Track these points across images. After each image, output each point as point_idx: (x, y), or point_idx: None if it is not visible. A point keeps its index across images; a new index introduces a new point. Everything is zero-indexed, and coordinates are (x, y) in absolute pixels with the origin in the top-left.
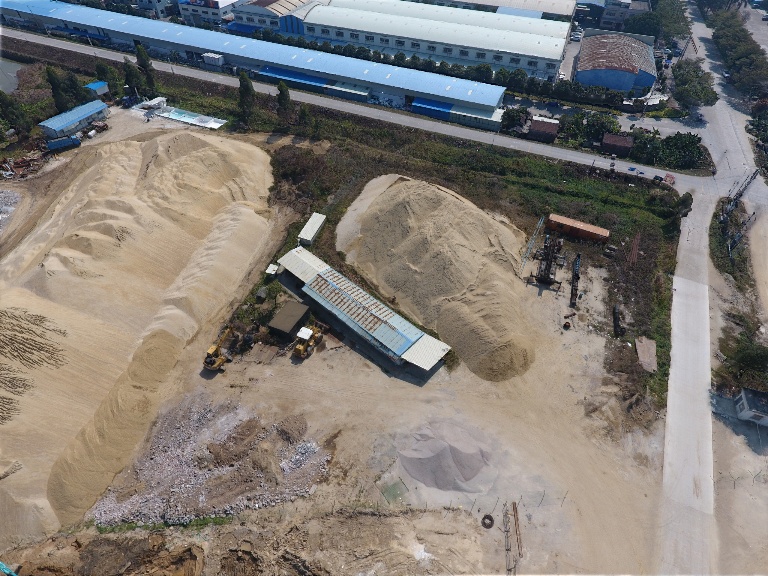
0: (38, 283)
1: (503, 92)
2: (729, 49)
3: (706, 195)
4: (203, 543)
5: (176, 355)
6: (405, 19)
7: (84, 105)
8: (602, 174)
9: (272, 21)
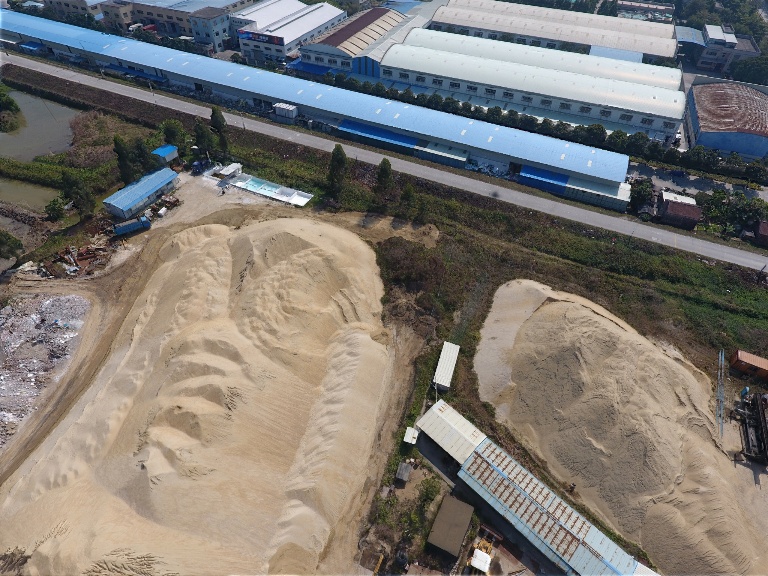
0: (139, 495)
1: (627, 163)
2: None
3: None
4: None
5: None
6: (495, 64)
7: (152, 175)
8: None
9: (344, 62)
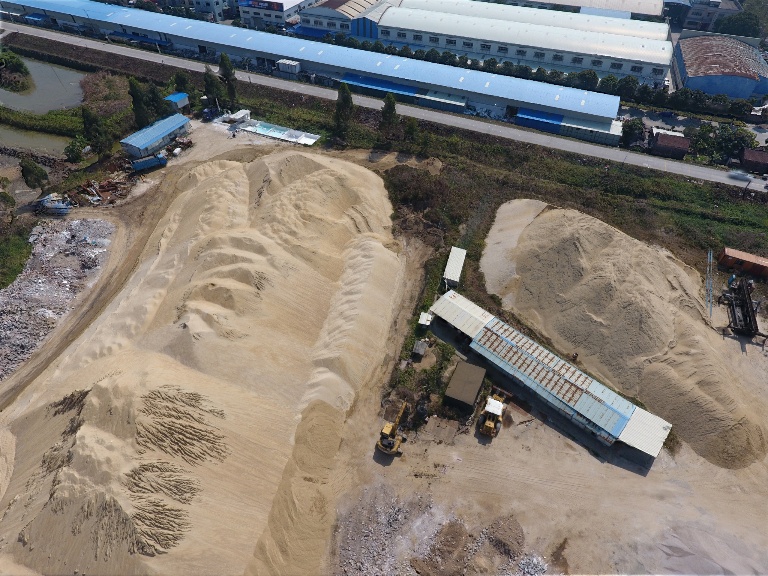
0: (183, 349)
1: (618, 102)
2: None
3: None
4: None
5: (338, 432)
6: (489, 21)
7: (165, 119)
8: (758, 197)
9: (342, 24)
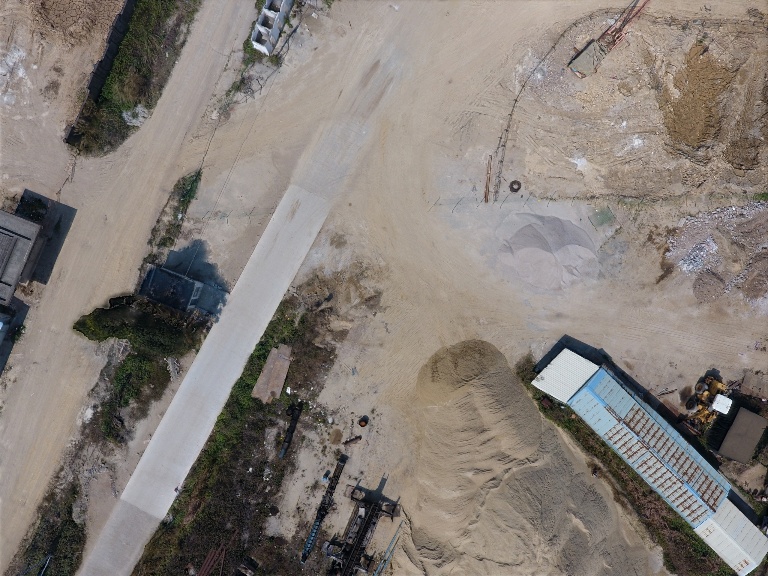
0: None
1: None
2: None
3: None
4: None
5: None
6: None
7: None
8: None
9: None
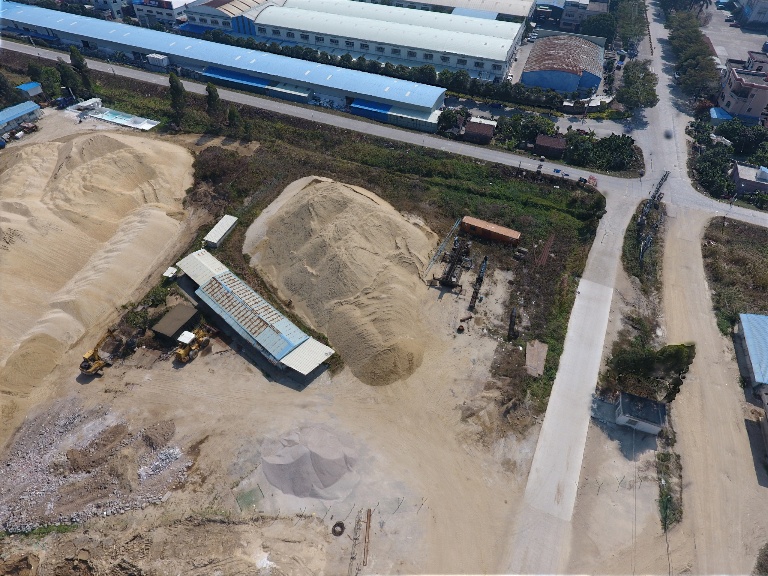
0: None
1: (442, 93)
2: (680, 50)
3: (629, 197)
4: (40, 552)
5: (56, 359)
6: (356, 20)
7: (14, 106)
8: (528, 176)
9: (224, 22)
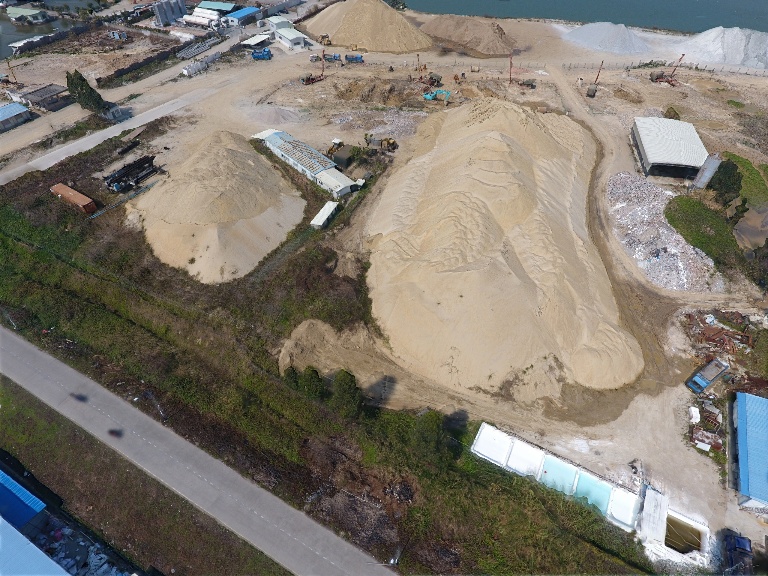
0: None
1: None
2: None
3: None
4: None
5: None
6: None
7: None
8: None
9: None
